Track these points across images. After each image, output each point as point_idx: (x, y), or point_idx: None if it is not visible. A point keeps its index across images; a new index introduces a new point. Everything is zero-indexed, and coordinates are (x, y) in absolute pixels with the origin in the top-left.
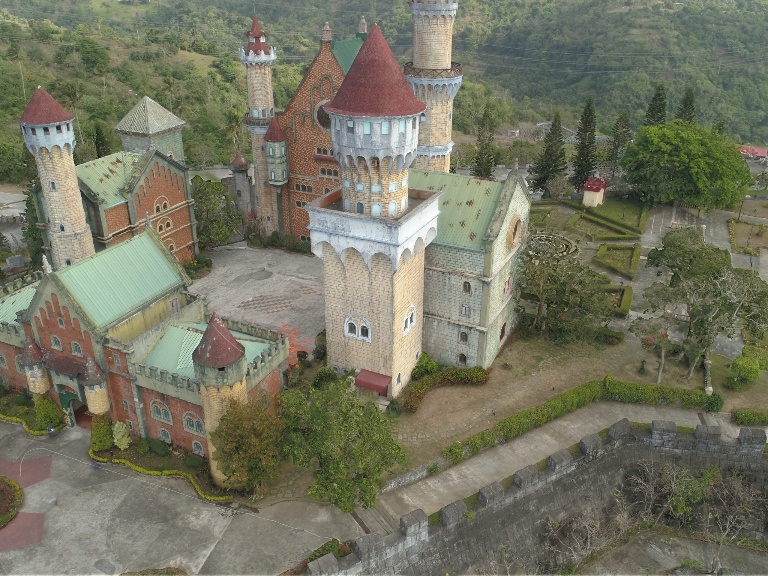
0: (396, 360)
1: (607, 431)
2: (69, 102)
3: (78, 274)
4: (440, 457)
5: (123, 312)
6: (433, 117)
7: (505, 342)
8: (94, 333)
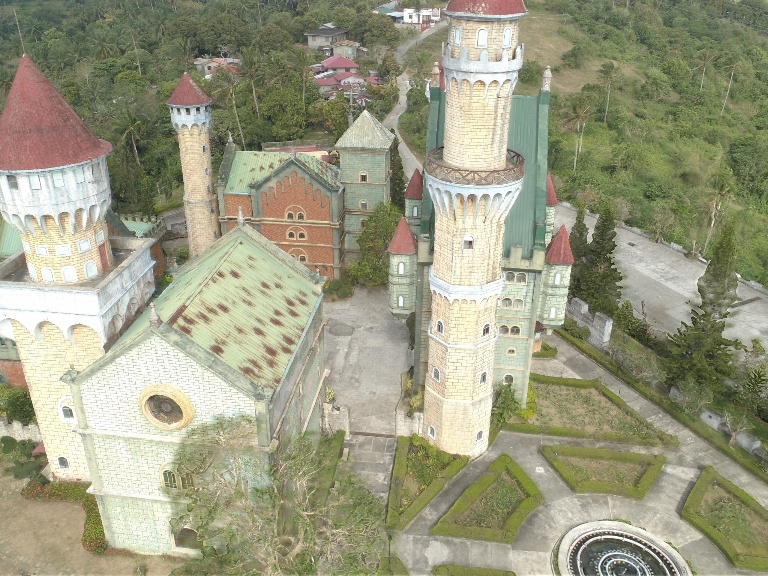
0: (52, 438)
1: None
2: (572, 114)
3: None
4: None
5: None
6: (438, 233)
7: (201, 557)
8: None
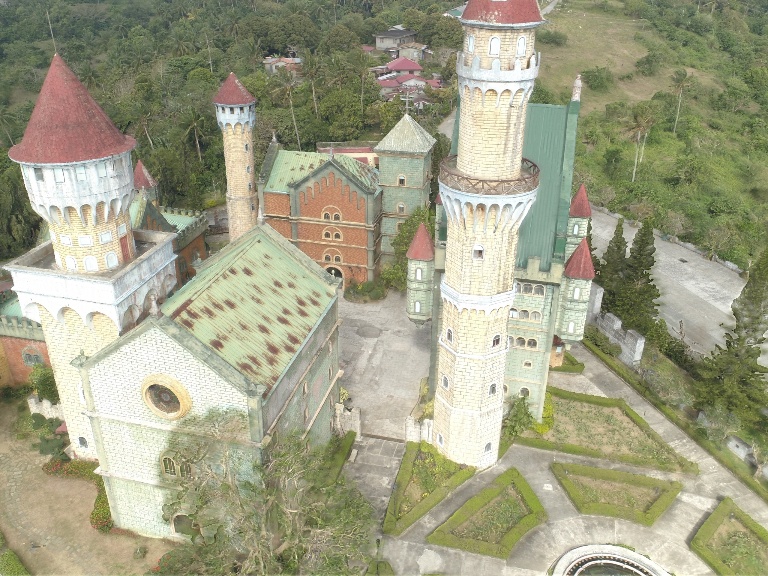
0: (73, 418)
1: None
2: (633, 123)
3: None
4: None
5: None
6: (449, 241)
7: None
8: (39, 240)
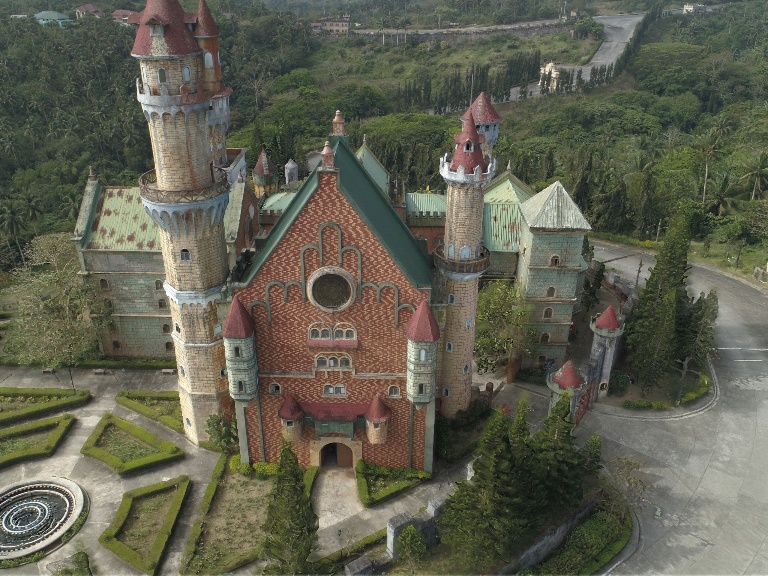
0: None
1: (53, 301)
2: None
3: None
4: None
5: None
6: None
7: None
8: None
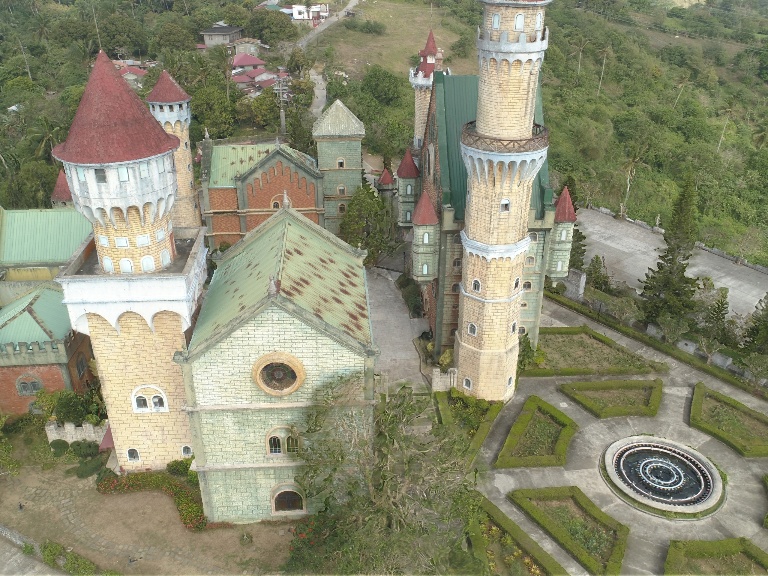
0: (122, 431)
1: None
2: None
3: (21, 218)
4: (39, 544)
5: (30, 261)
6: (474, 200)
7: (300, 518)
8: None
